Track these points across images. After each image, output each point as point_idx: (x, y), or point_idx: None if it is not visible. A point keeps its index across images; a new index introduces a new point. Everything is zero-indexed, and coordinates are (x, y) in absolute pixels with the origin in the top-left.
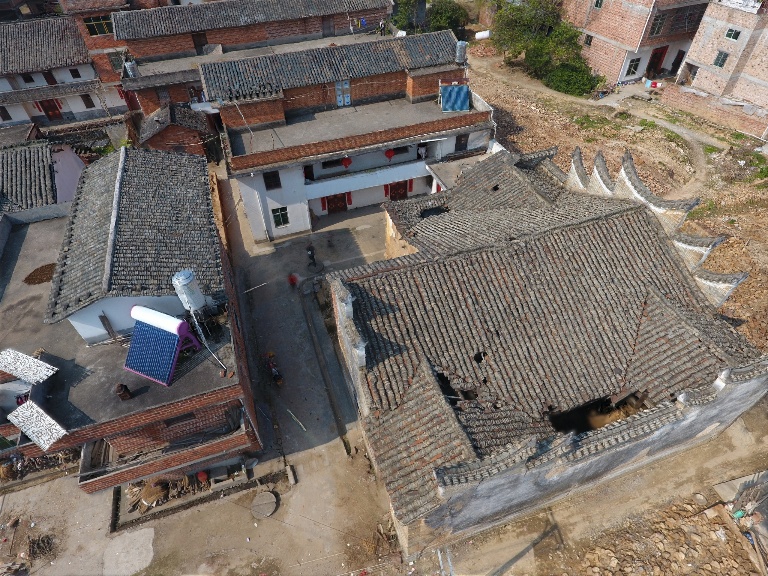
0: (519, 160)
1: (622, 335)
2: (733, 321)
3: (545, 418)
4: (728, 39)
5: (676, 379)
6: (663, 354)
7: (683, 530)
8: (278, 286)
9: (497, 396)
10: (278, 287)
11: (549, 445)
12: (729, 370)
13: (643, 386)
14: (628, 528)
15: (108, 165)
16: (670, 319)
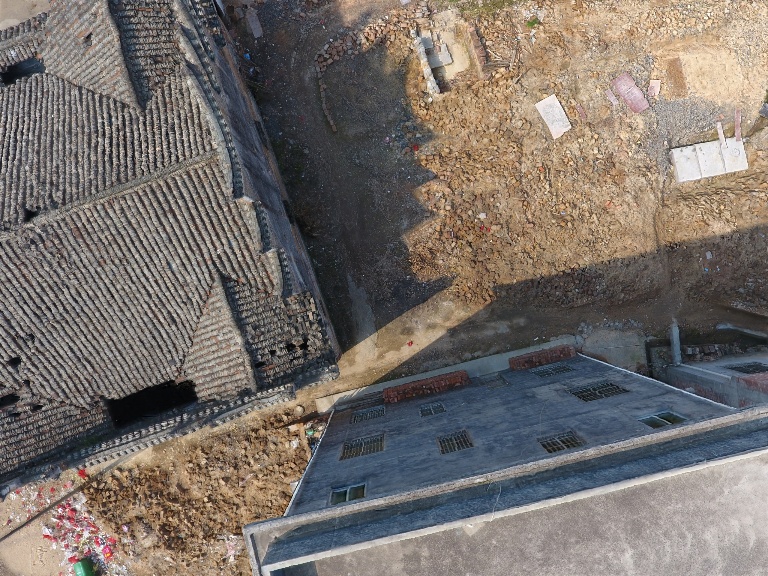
0: None
1: (180, 327)
2: (431, 213)
3: (99, 405)
4: None
5: (213, 383)
6: (211, 355)
7: (267, 439)
8: None
9: (40, 396)
10: None
11: (40, 476)
12: (206, 424)
13: (193, 379)
14: (232, 431)
15: None
16: (225, 318)
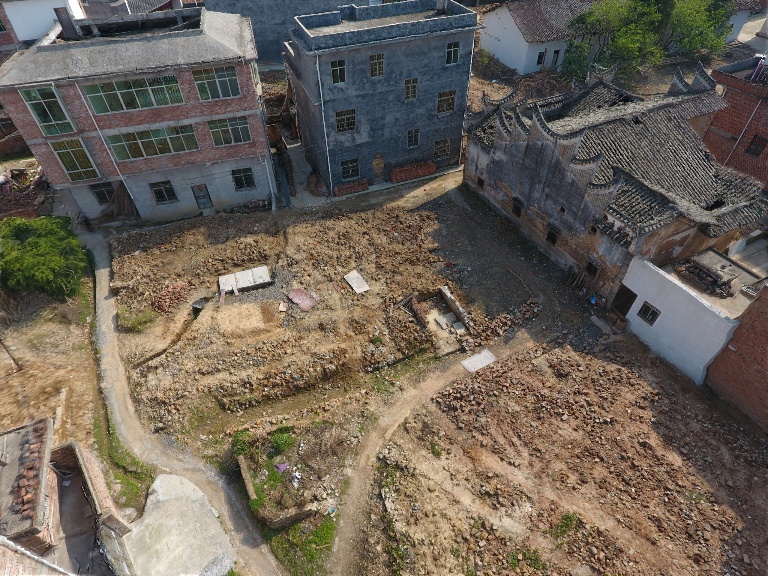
0: None
1: None
2: (429, 235)
3: None
4: None
5: None
6: None
7: None
8: None
9: None
10: None
11: None
12: None
13: None
14: None
15: None
16: None
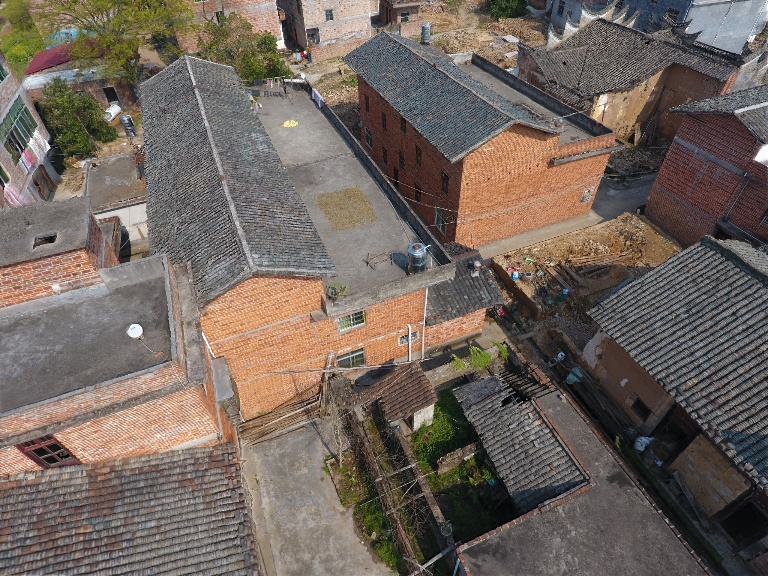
0: (544, 49)
1: None
2: None
3: None
4: (326, 1)
5: None
6: None
7: None
8: (628, 199)
9: None
10: (629, 199)
11: None
12: None
13: None
14: None
15: (763, 116)
16: None
